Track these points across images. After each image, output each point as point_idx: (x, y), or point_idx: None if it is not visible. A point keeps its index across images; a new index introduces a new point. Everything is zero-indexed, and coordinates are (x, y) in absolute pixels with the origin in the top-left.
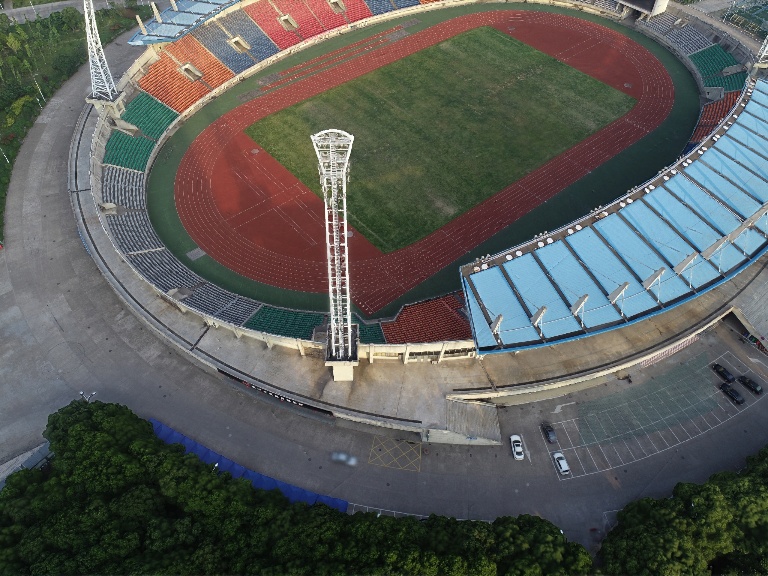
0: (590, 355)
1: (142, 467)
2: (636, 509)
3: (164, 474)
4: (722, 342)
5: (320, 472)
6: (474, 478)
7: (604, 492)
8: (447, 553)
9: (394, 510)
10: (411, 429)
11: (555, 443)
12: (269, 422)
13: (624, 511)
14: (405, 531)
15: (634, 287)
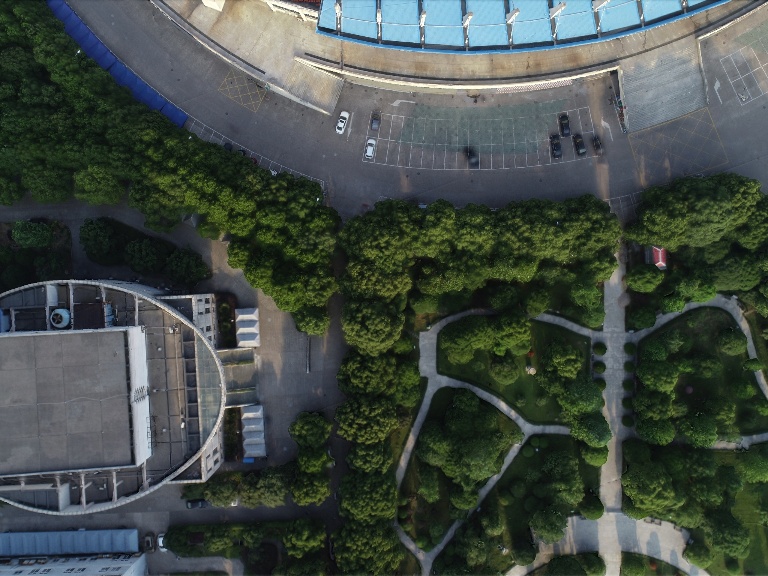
0: (446, 65)
1: (22, 31)
2: (387, 205)
3: (37, 44)
4: (591, 96)
5: (177, 83)
6: (296, 134)
7: (391, 182)
8: (225, 182)
9: (224, 135)
10: (254, 76)
11: (376, 131)
12: (148, 23)
13: (381, 202)
14: (202, 156)
15: (497, 16)
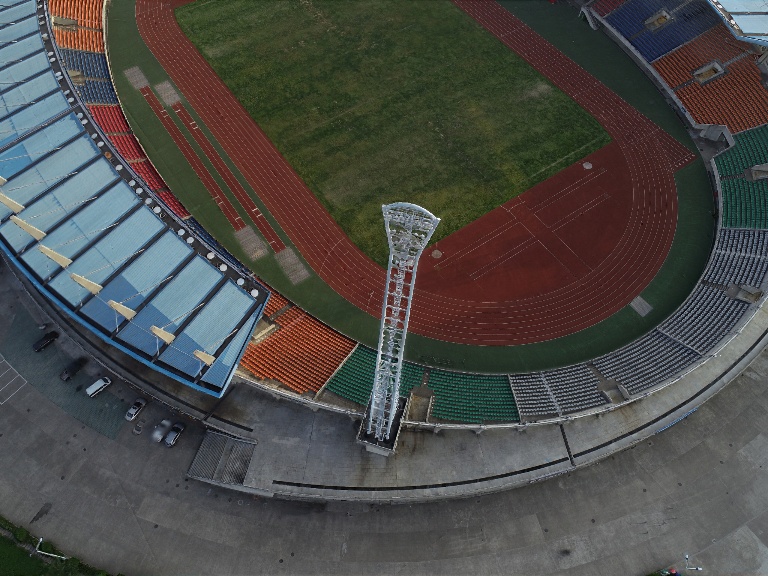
0: None
1: None
2: None
3: None
4: None
5: None
6: None
7: None
8: None
9: None
10: None
11: None
12: None
13: None
14: None
15: None
